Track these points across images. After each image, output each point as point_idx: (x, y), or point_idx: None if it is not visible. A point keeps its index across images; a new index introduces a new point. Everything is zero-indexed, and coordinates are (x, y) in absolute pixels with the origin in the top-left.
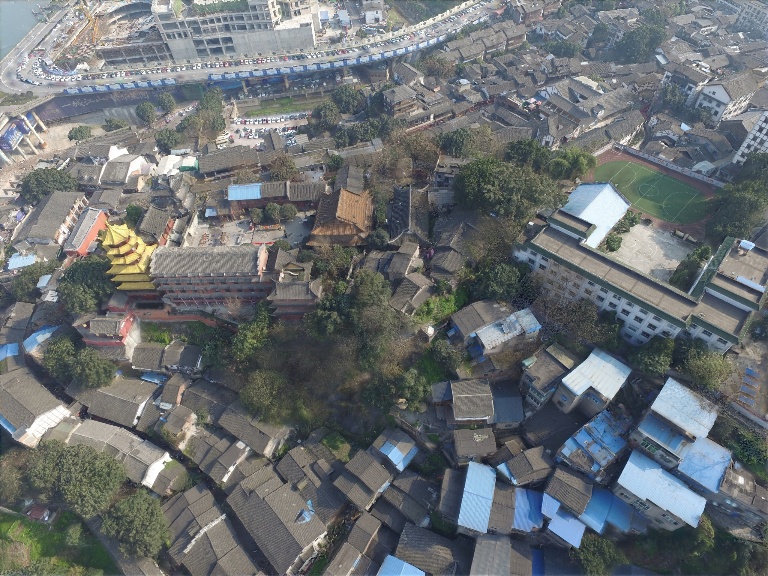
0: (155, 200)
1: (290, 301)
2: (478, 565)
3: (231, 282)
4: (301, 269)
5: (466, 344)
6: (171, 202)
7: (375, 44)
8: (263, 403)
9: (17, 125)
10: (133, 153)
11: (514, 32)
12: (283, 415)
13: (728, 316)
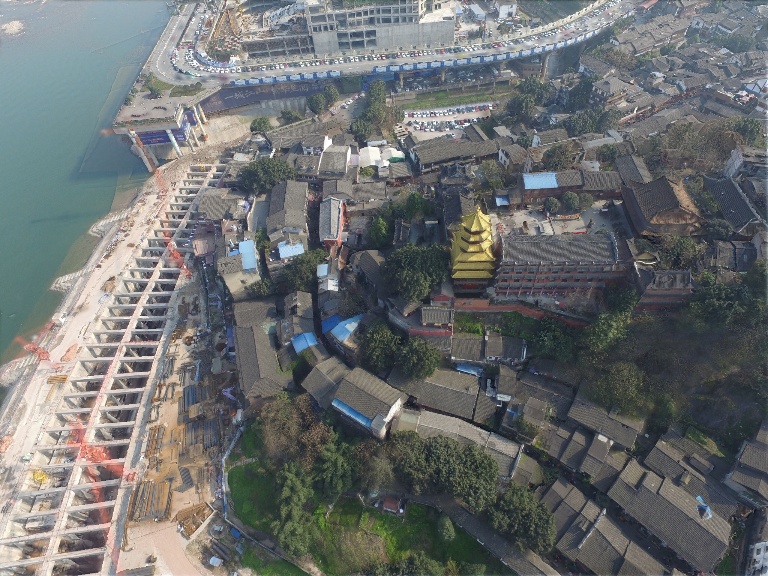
0: (447, 188)
1: (663, 291)
2: None
3: (579, 271)
4: (651, 258)
5: None
6: (462, 191)
7: (528, 38)
8: (626, 395)
9: (188, 116)
10: (333, 144)
11: (678, 26)
12: (651, 408)
13: None
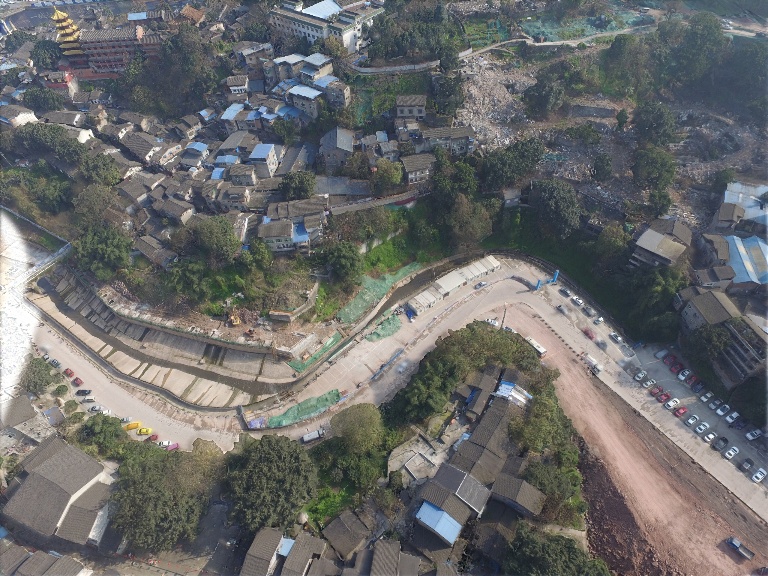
0: None
1: (152, 46)
2: (231, 137)
3: (124, 45)
4: None
5: (239, 61)
6: None
7: None
8: (140, 101)
9: None
10: None
11: None
12: (150, 106)
13: (345, 25)
